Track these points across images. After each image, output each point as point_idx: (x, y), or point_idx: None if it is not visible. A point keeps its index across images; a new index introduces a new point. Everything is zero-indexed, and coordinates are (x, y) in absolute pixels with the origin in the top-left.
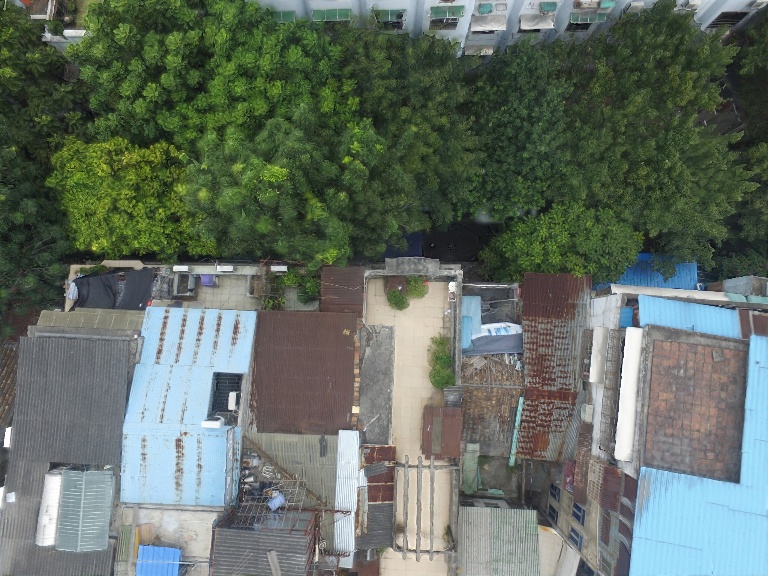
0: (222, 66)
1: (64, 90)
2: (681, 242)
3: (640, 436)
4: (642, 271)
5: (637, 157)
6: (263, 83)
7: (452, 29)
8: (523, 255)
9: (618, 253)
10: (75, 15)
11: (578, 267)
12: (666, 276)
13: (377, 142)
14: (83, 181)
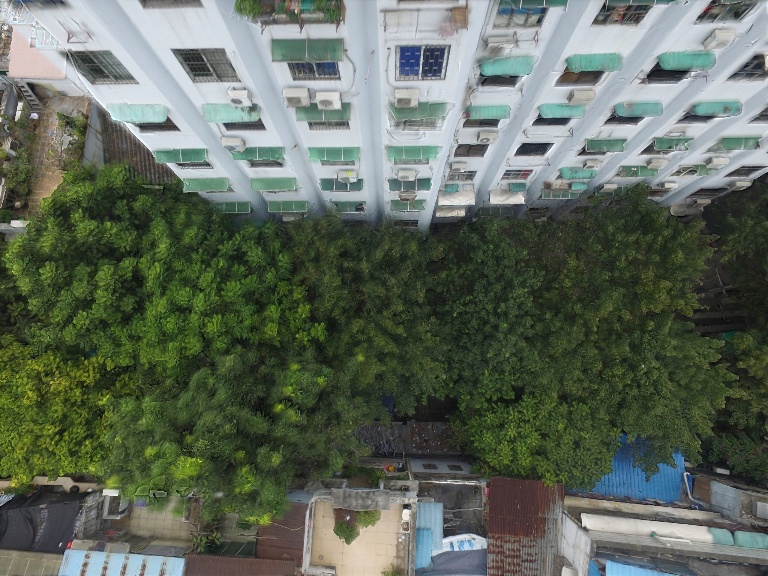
0: (156, 297)
1: (5, 287)
2: (662, 443)
3: None
4: (624, 456)
5: (612, 355)
6: (197, 320)
7: (416, 211)
8: (491, 452)
9: (592, 465)
10: (28, 197)
11: (549, 474)
12: (648, 474)
13: (321, 374)
14: (8, 406)
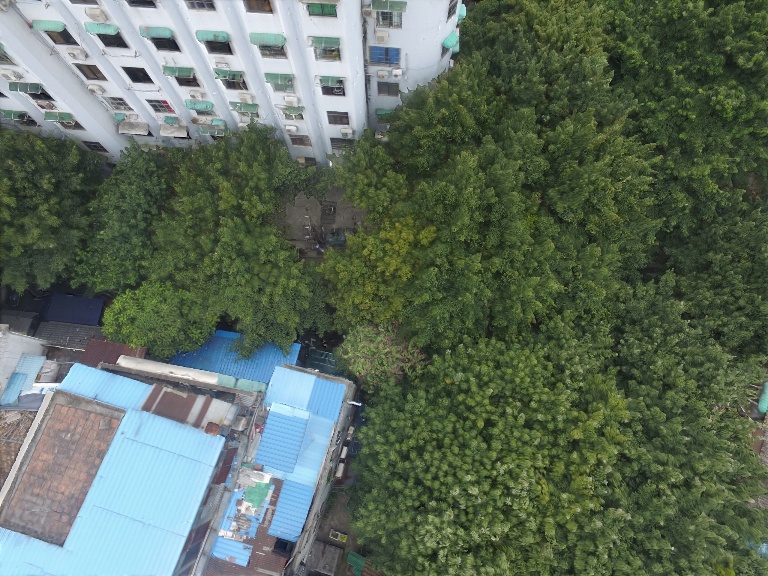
0: None
1: None
2: (243, 327)
3: (7, 492)
4: None
5: None
6: None
7: (84, 130)
8: (106, 324)
9: (162, 330)
10: None
11: (136, 339)
12: (239, 357)
13: None
14: None
